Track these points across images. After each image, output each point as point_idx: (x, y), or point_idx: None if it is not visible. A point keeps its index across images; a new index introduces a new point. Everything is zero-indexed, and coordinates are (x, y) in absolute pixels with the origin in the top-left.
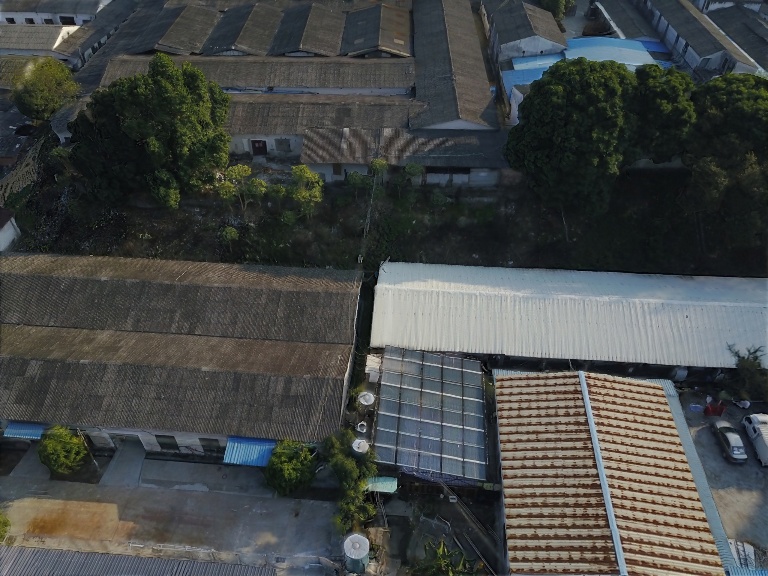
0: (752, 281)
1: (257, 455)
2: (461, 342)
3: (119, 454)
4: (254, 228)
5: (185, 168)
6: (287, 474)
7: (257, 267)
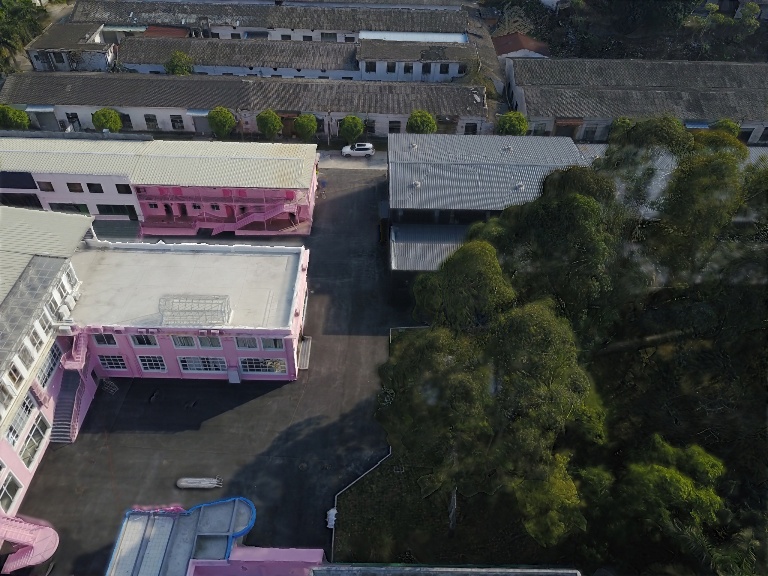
0: None
1: None
2: None
3: None
4: None
5: (690, 2)
6: None
7: None
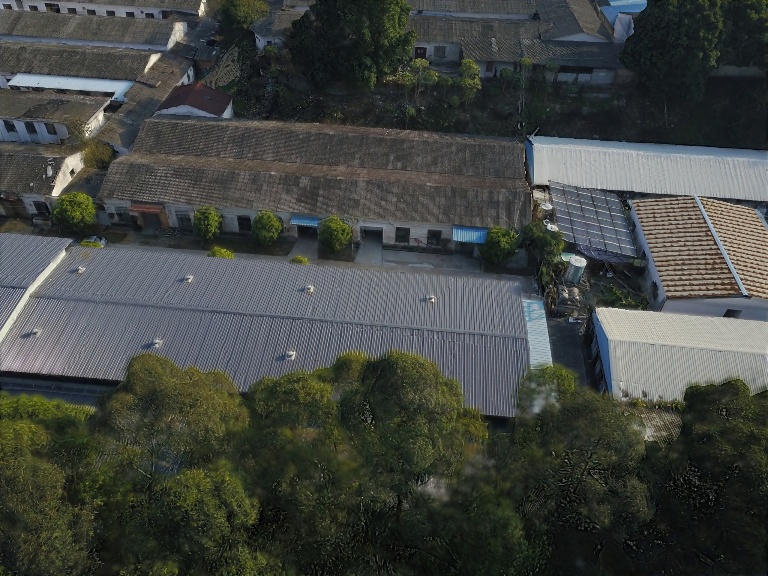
0: None
1: (476, 237)
2: (601, 183)
3: (363, 246)
4: (425, 111)
5: (383, 57)
6: (503, 244)
7: (438, 133)
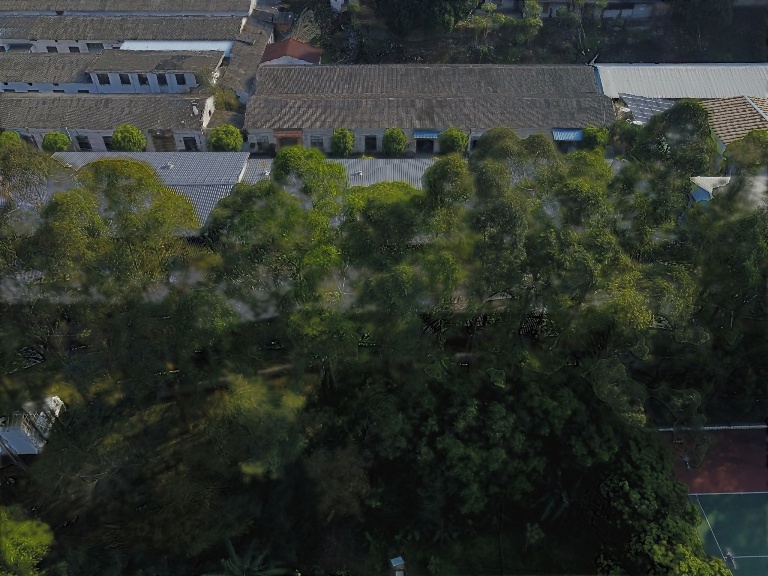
0: None
1: (573, 136)
2: (660, 93)
3: None
4: (493, 49)
5: (460, 2)
6: (599, 138)
7: (513, 64)
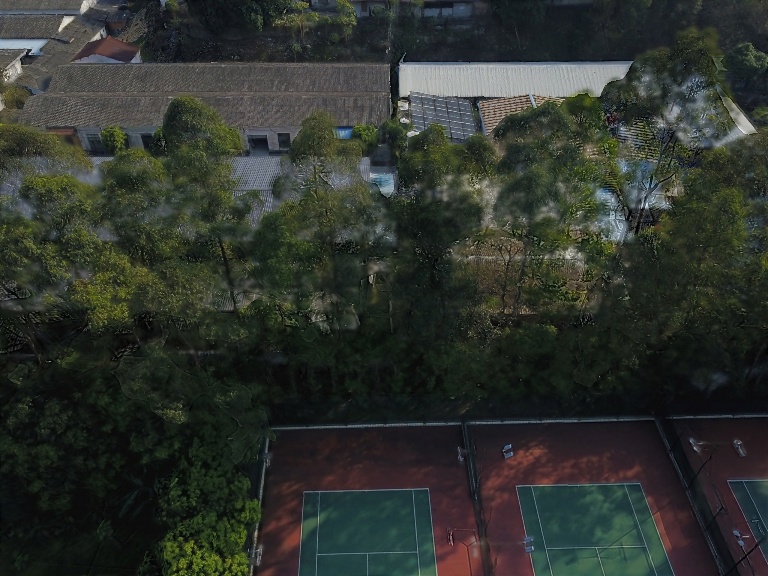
0: None
1: (343, 134)
2: (456, 92)
3: (252, 154)
4: (310, 48)
5: (267, 0)
6: (364, 137)
7: None
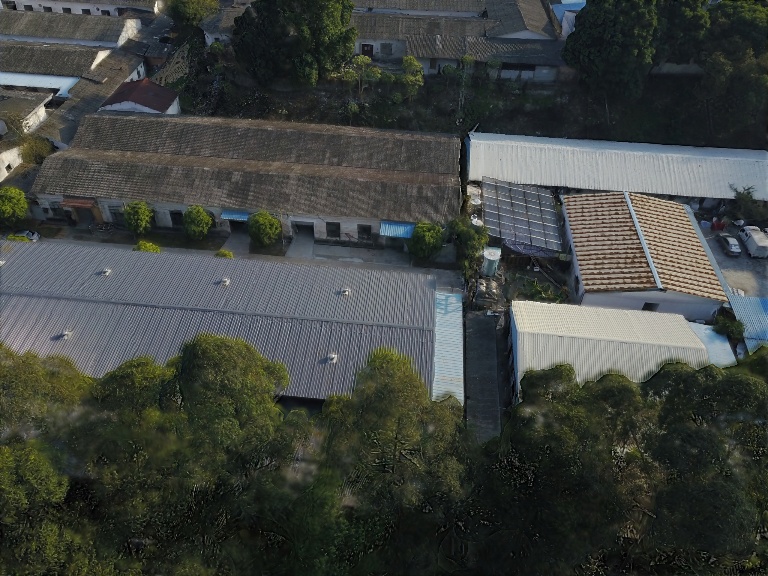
0: (748, 151)
1: (403, 231)
2: (535, 178)
3: (295, 241)
4: (369, 107)
5: (324, 54)
6: (428, 239)
7: (378, 129)
